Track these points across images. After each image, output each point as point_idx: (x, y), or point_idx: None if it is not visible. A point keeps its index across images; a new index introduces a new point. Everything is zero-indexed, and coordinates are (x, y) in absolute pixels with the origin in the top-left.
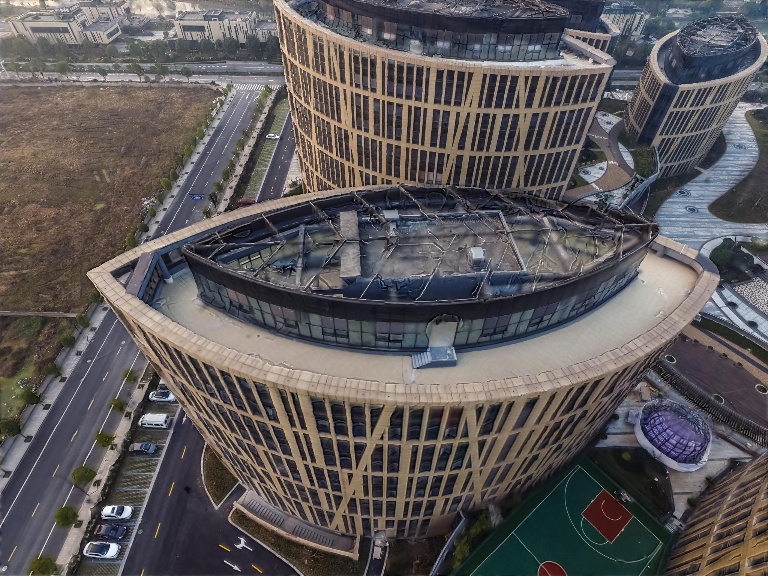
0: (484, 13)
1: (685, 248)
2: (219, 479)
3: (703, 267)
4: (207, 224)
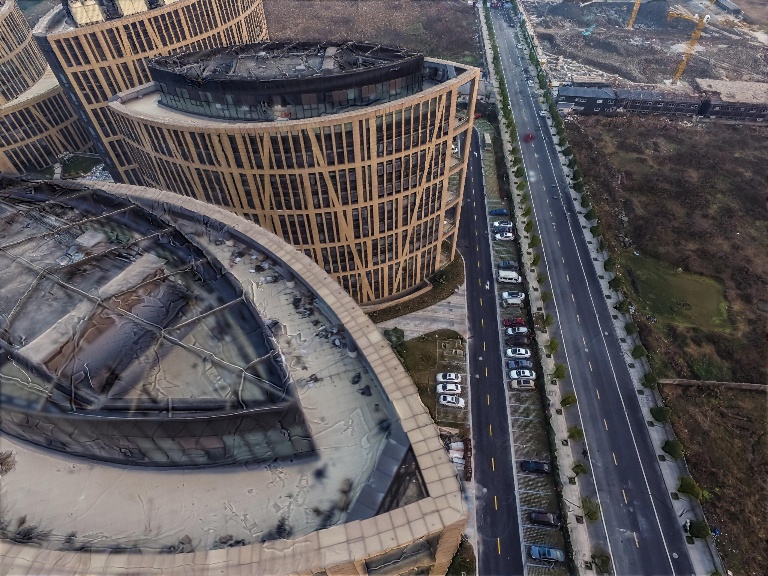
0: (13, 179)
1: (114, 103)
2: (447, 248)
3: (118, 98)
4: (426, 92)
